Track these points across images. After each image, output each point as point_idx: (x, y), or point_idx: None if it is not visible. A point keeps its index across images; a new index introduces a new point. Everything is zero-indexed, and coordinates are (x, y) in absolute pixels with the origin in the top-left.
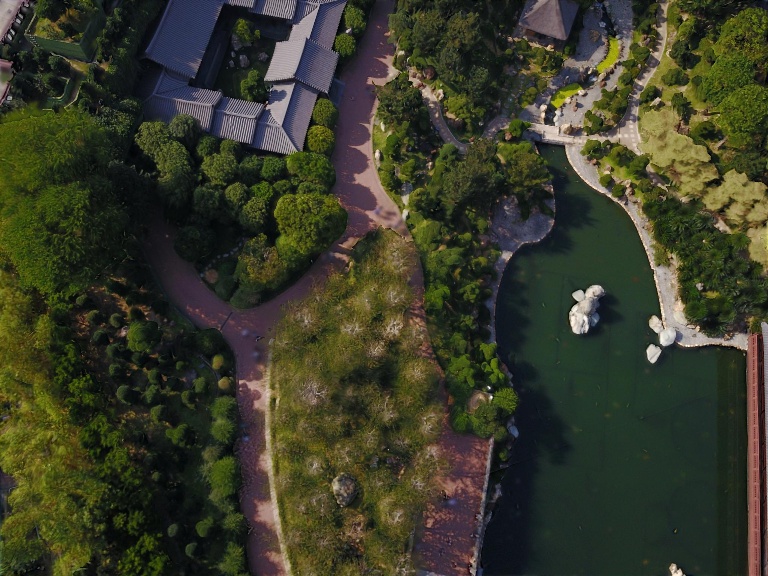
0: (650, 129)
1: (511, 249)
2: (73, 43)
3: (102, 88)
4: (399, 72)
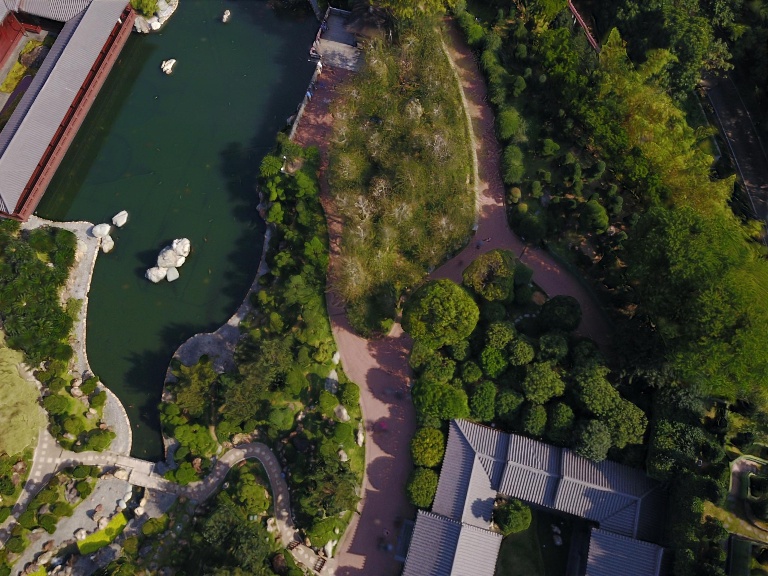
0: (27, 425)
1: (228, 328)
2: (761, 544)
3: (703, 478)
4: (320, 573)
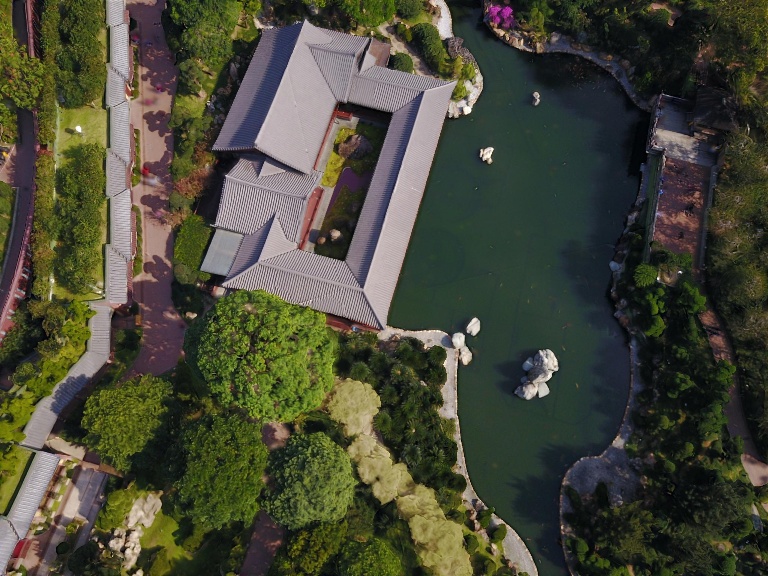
0: None
1: (614, 450)
2: None
3: None
4: None
